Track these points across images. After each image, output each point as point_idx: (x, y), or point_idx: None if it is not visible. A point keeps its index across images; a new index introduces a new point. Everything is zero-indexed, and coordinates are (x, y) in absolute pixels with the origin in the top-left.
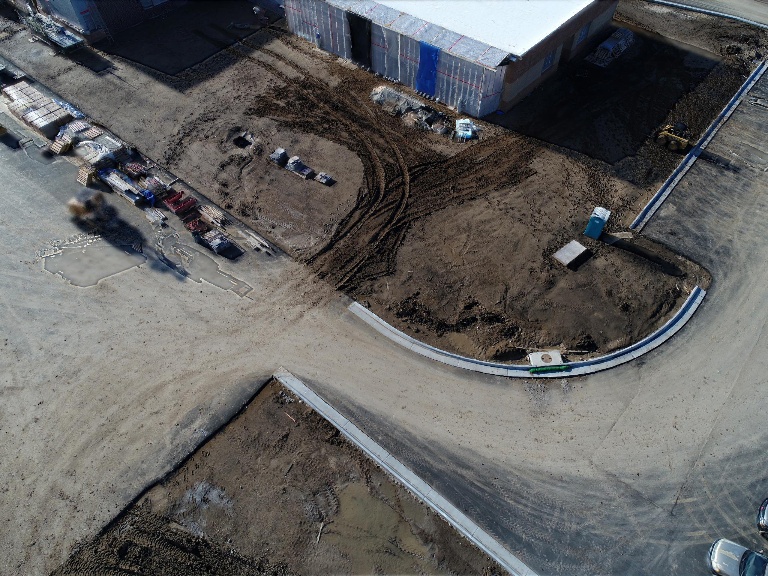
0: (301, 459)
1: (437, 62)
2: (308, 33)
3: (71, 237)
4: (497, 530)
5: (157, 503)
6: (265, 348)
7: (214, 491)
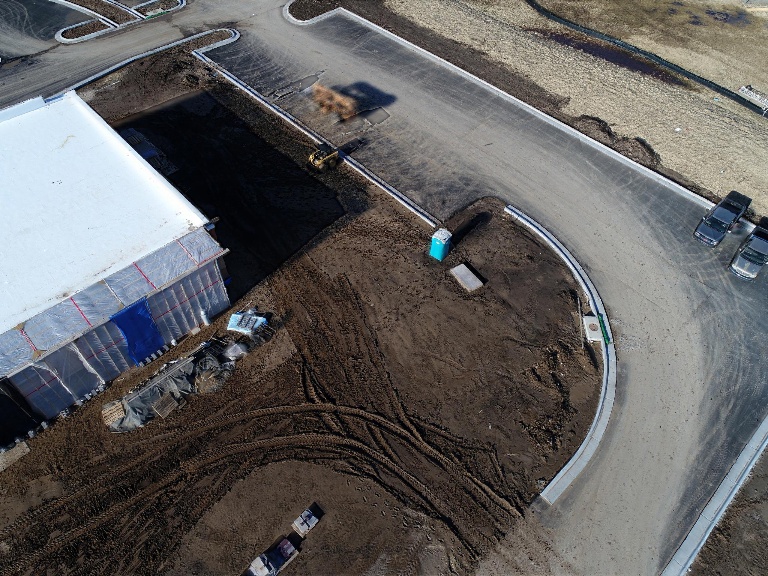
0: (756, 571)
1: (150, 312)
2: None
3: None
4: (766, 400)
5: None
6: None
7: None
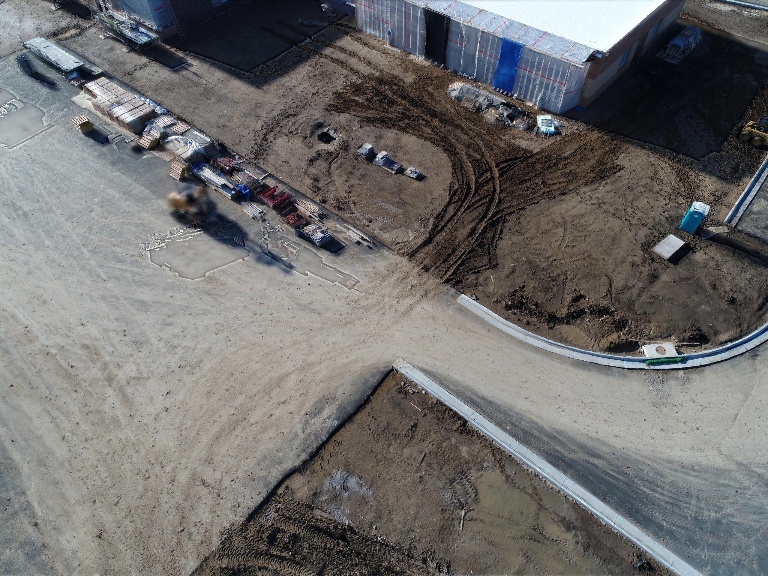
0: (433, 448)
1: (519, 58)
2: (378, 30)
3: (172, 230)
4: (637, 518)
5: (298, 491)
6: (381, 340)
7: (352, 479)
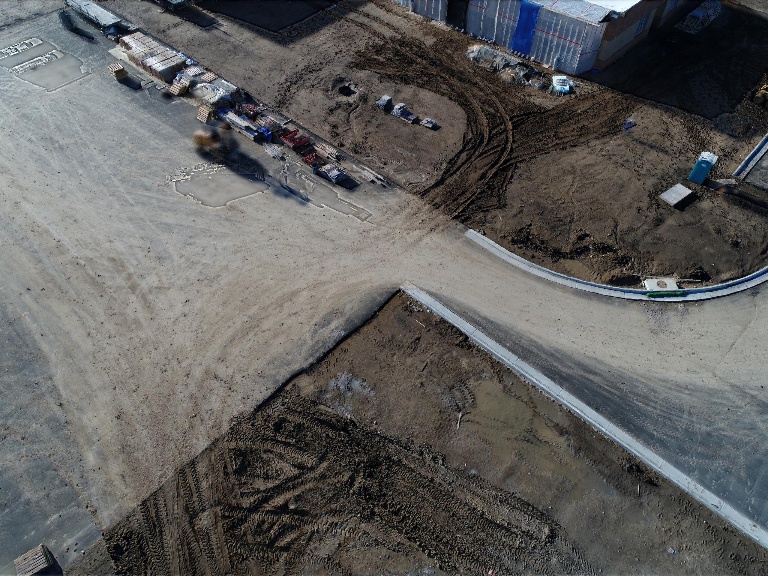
0: (434, 359)
1: (537, 20)
2: None
3: (197, 165)
4: (629, 427)
5: (304, 388)
6: (390, 265)
7: (356, 381)
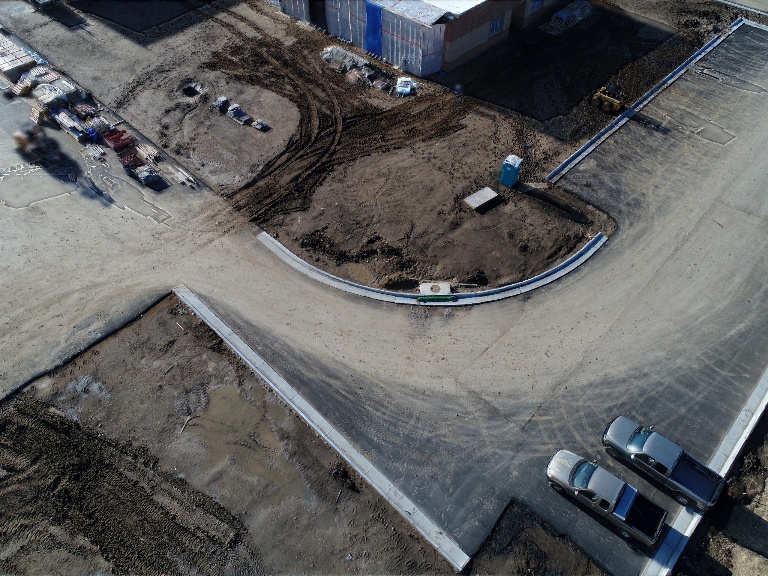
0: (182, 362)
1: (381, 21)
2: None
3: (14, 166)
4: (351, 432)
5: (41, 391)
6: (170, 267)
7: (95, 384)
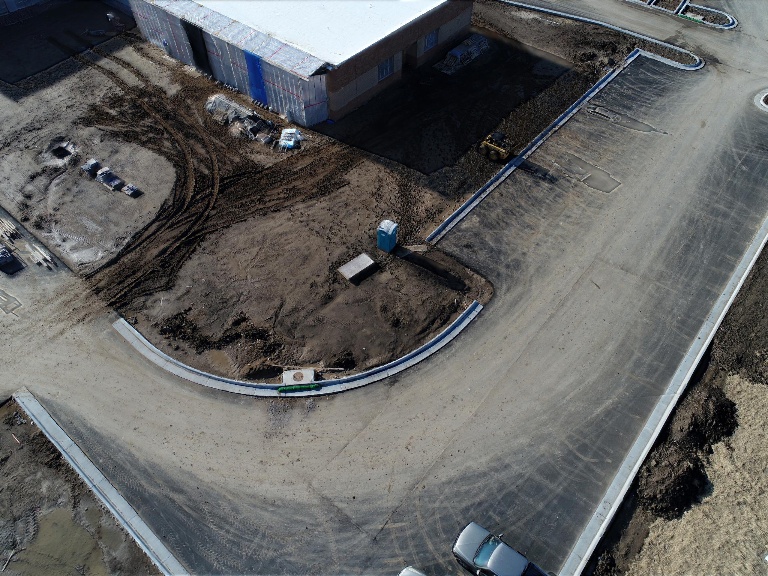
0: (13, 483)
1: (261, 71)
2: (158, 40)
3: None
4: (190, 557)
5: None
6: (14, 367)
7: None
